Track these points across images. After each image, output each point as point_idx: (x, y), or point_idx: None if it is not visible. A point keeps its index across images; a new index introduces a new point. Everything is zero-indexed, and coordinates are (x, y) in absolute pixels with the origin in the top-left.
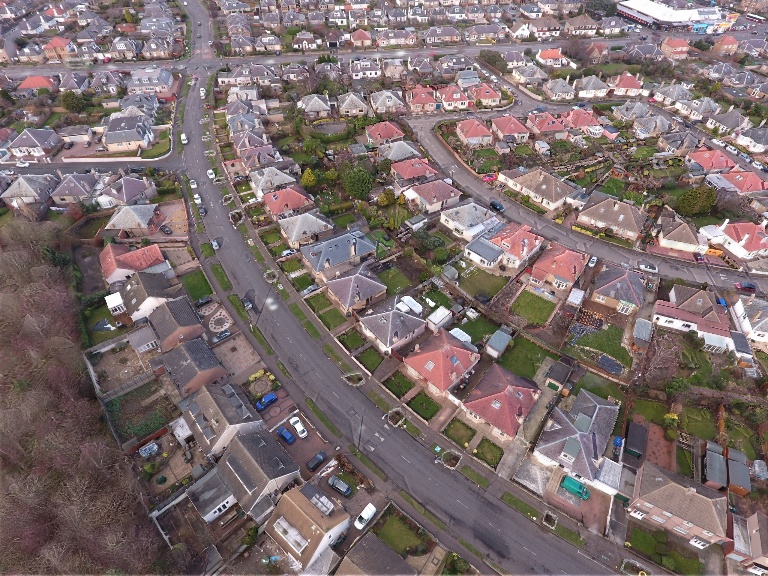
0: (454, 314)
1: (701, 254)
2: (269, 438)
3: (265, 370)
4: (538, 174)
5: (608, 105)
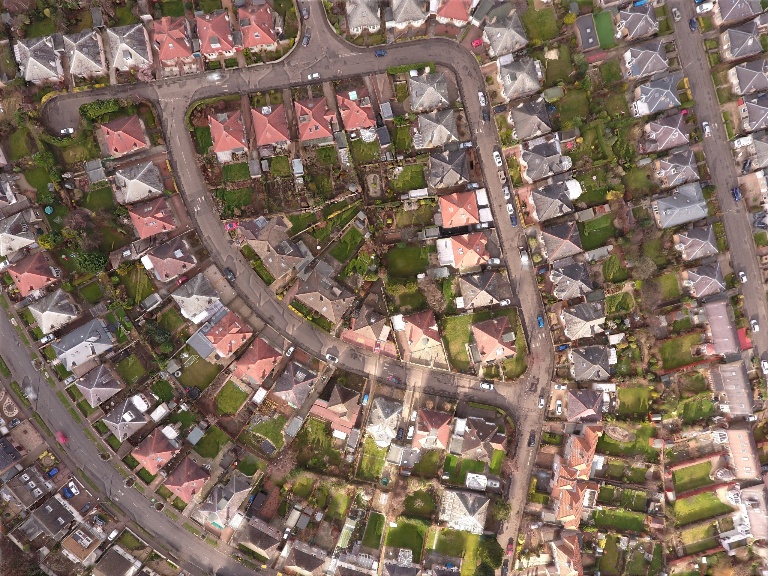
0: (170, 410)
1: None
2: (55, 503)
3: (48, 451)
4: (266, 246)
5: (405, 70)
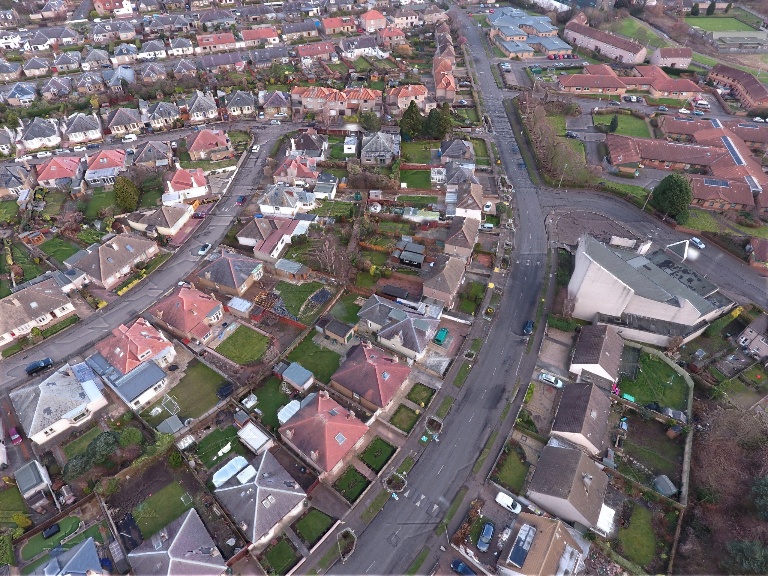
0: None
1: None
2: None
3: None
4: (5, 305)
5: None
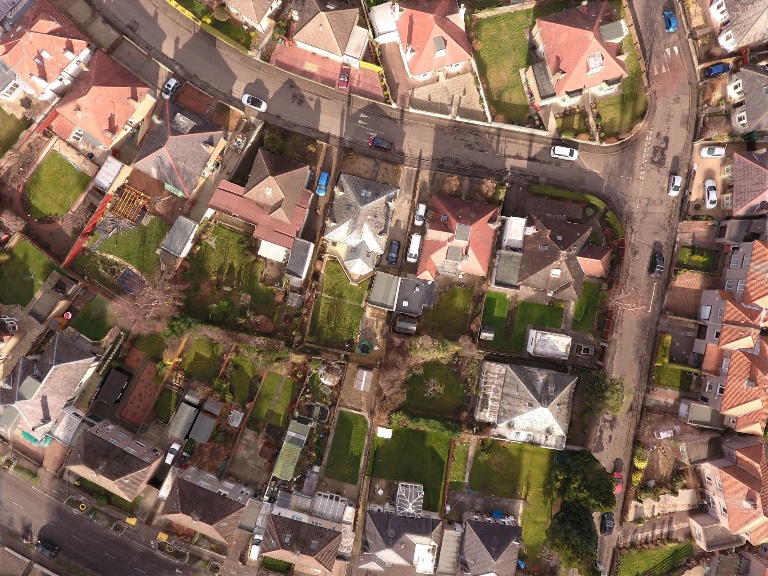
0: None
1: (353, 68)
2: None
3: None
4: None
5: None
